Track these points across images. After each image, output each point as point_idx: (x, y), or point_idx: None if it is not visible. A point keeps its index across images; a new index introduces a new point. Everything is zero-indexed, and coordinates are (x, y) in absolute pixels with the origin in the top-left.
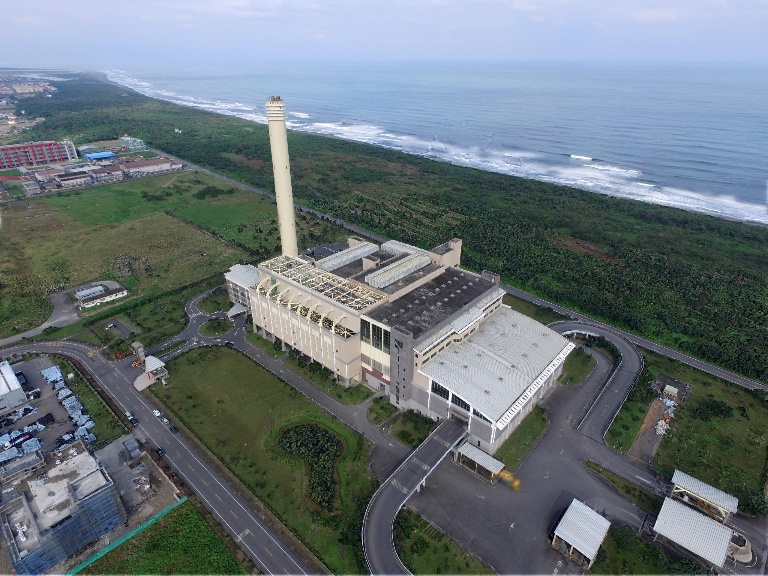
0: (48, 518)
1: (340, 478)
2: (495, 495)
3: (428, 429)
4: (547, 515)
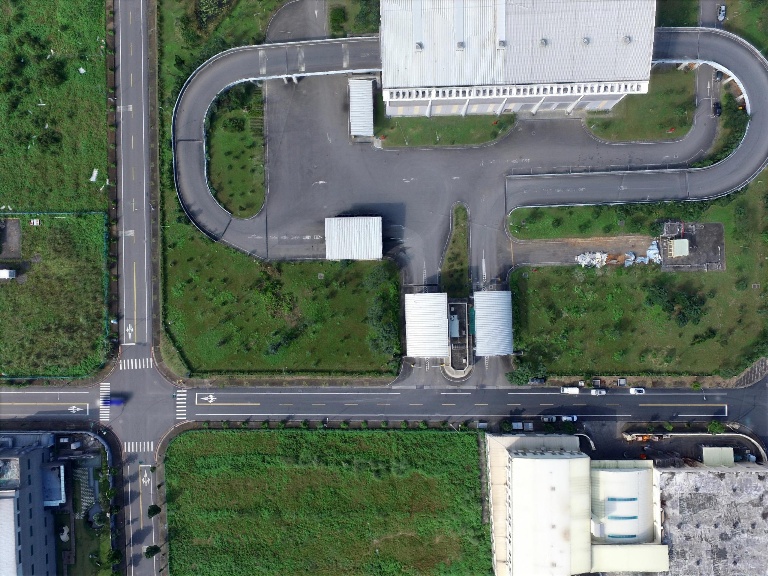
0: None
1: (238, 4)
2: (341, 149)
3: (369, 30)
4: (359, 204)
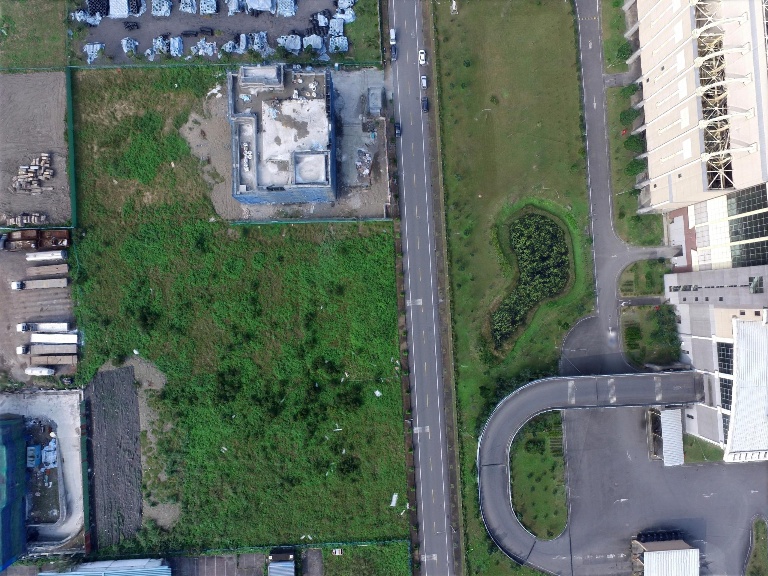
0: (268, 171)
1: (532, 322)
2: (642, 467)
3: None
4: (661, 521)
